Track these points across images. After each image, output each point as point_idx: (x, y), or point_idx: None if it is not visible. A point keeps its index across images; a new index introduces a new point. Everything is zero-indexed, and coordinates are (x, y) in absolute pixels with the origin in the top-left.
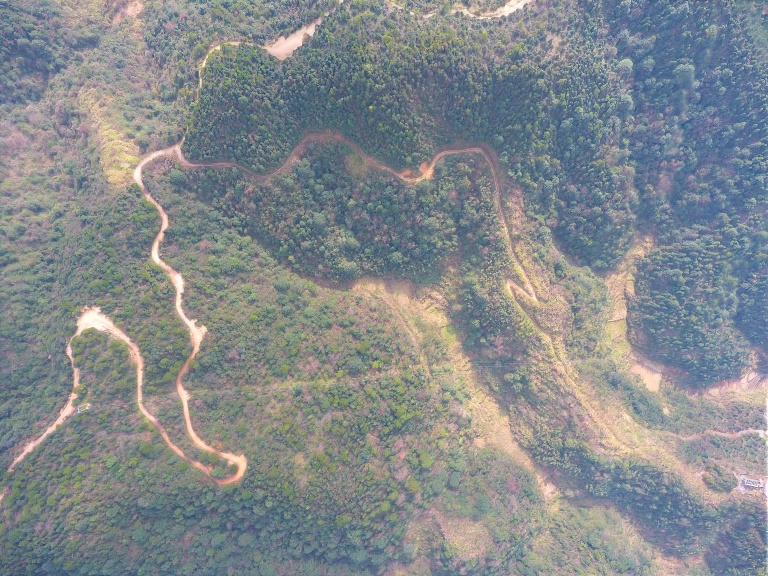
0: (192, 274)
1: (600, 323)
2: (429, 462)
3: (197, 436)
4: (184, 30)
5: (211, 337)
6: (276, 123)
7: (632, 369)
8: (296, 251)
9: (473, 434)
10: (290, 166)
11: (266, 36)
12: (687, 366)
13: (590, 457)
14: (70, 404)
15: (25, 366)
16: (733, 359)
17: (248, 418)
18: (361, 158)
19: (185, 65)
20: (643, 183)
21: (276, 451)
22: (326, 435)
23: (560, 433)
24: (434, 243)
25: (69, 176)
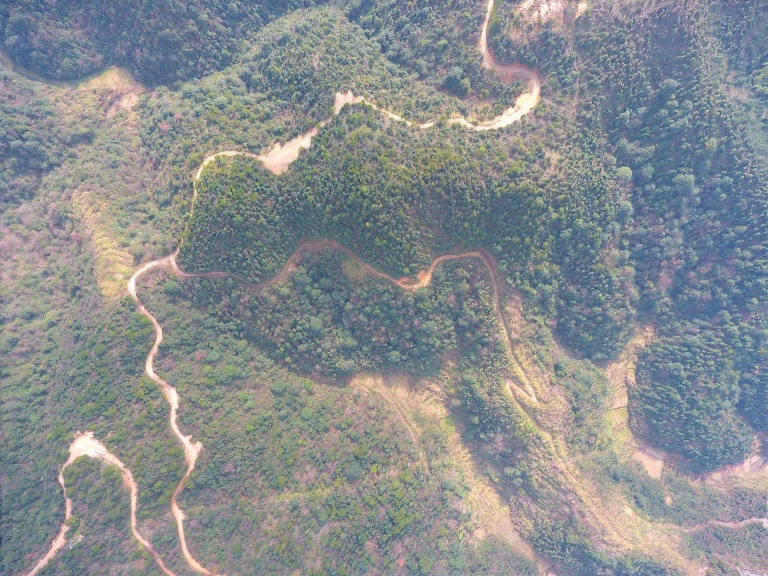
0: (187, 388)
1: (601, 414)
2: (429, 566)
3: (192, 558)
4: (179, 133)
5: (206, 454)
6: (272, 237)
7: (633, 456)
8: (293, 353)
9: (473, 527)
10: (286, 275)
11: (261, 144)
12: (689, 455)
13: (592, 554)
14: (62, 536)
15: (17, 489)
16: (736, 447)
17: (244, 536)
18: (358, 265)
19: (180, 172)
20: (643, 280)
21: (273, 572)
22: (324, 549)
23: (561, 527)
24: (432, 343)
25: (62, 280)
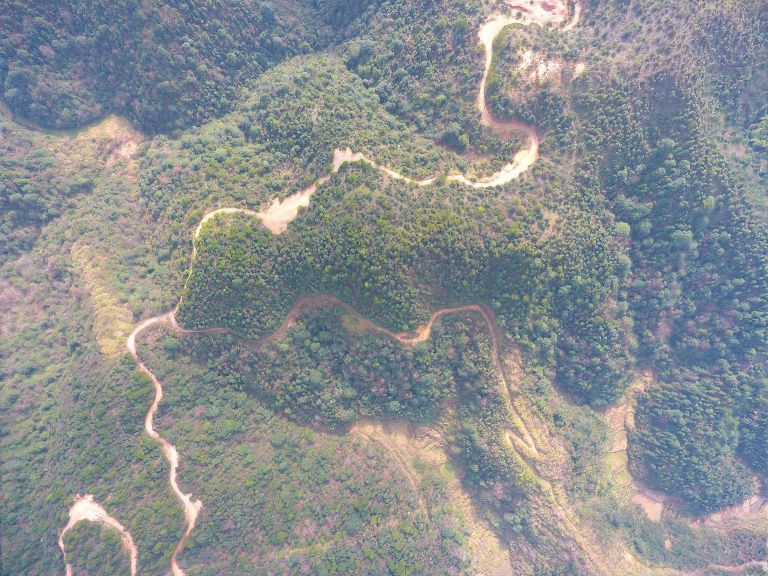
0: (187, 446)
1: (600, 459)
2: None
3: None
4: (178, 186)
5: (206, 512)
6: (271, 296)
7: (633, 499)
8: (292, 404)
9: (473, 572)
10: (285, 331)
11: (260, 200)
12: (689, 499)
13: None
14: None
15: (17, 551)
16: (735, 490)
17: None
18: (357, 319)
19: (179, 227)
20: (642, 329)
21: None
22: None
23: (561, 573)
24: None
25: (62, 334)
